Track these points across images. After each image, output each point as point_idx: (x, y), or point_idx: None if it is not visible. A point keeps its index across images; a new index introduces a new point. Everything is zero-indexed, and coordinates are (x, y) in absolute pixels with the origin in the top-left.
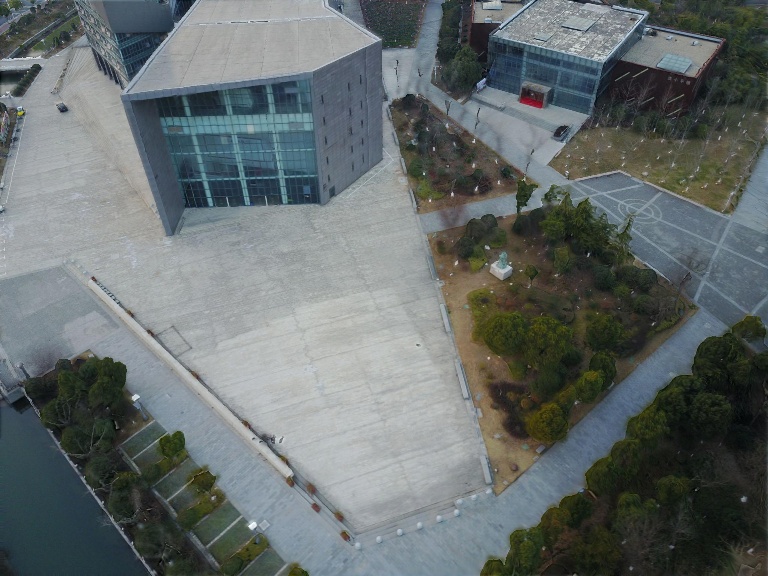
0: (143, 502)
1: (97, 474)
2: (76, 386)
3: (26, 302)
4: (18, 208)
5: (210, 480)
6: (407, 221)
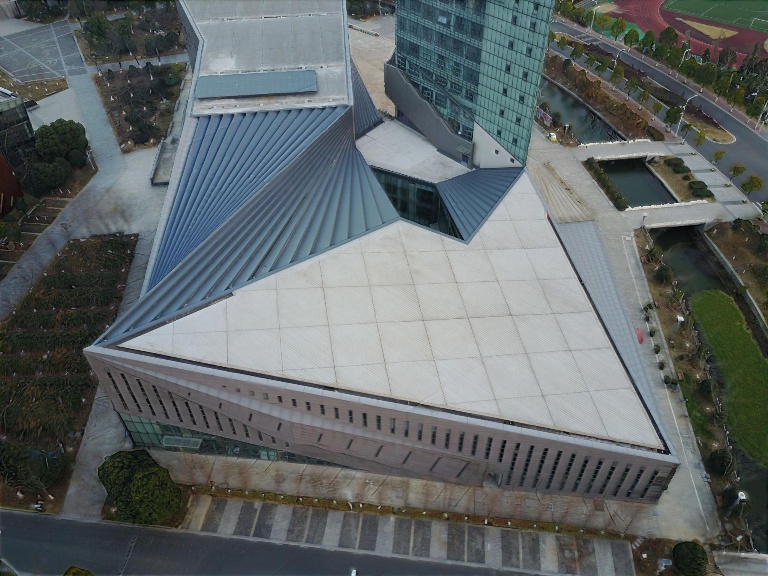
0: None
1: None
2: None
3: None
4: None
5: None
6: None
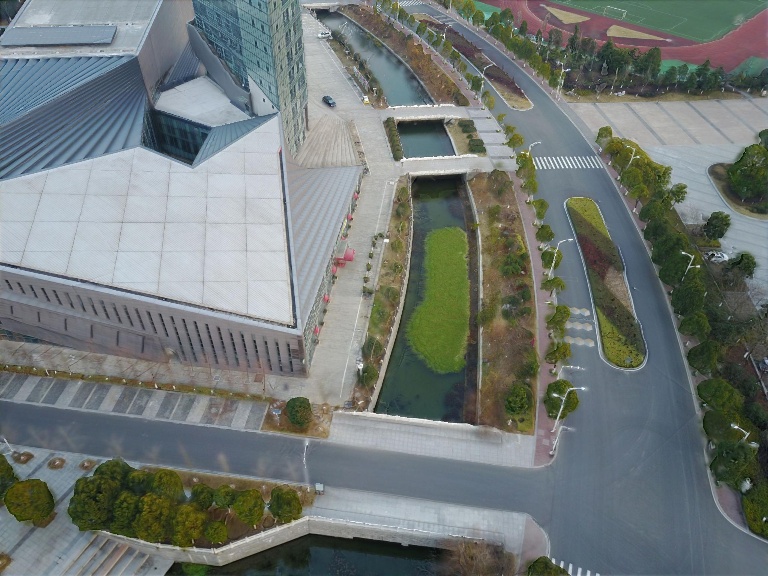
0: None
1: None
2: None
3: None
4: (310, 38)
5: None
6: None
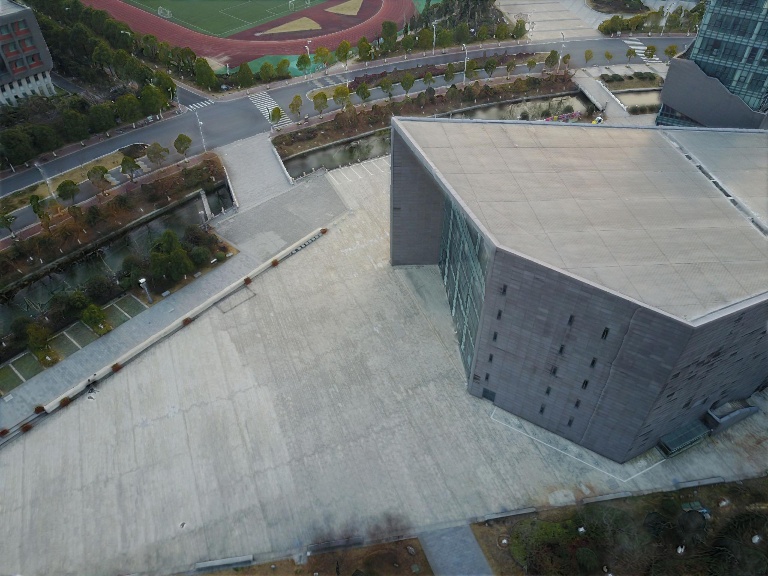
0: (57, 314)
1: (87, 282)
2: (163, 244)
3: (302, 204)
4: None
5: (33, 341)
6: (447, 506)
